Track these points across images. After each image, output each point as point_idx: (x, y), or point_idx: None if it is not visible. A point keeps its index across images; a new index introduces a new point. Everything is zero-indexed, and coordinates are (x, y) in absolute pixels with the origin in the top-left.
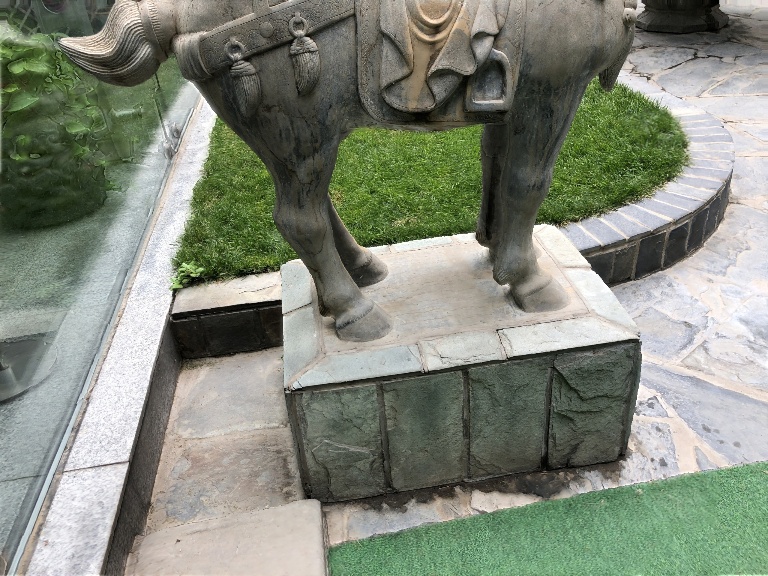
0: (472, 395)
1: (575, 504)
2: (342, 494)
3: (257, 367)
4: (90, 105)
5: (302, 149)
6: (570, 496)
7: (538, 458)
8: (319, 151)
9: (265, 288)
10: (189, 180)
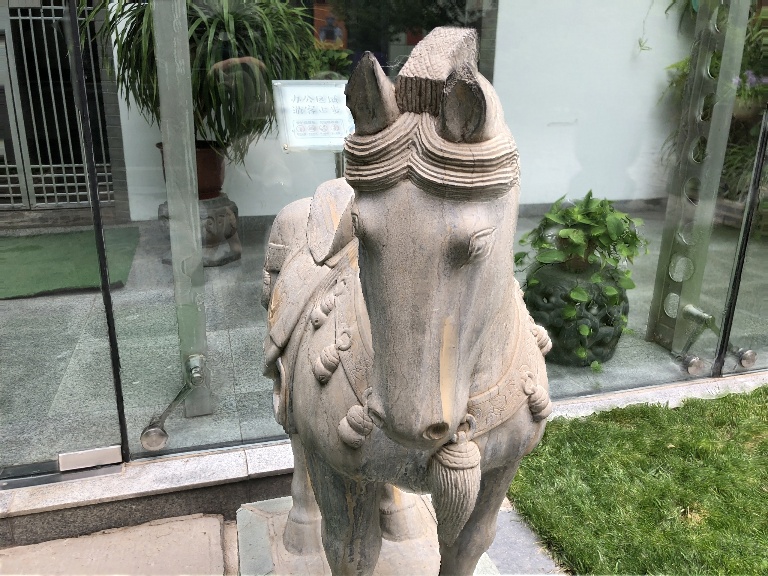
0: None
1: None
2: None
3: None
4: (676, 292)
5: None
6: None
7: None
8: None
9: None
10: (669, 401)
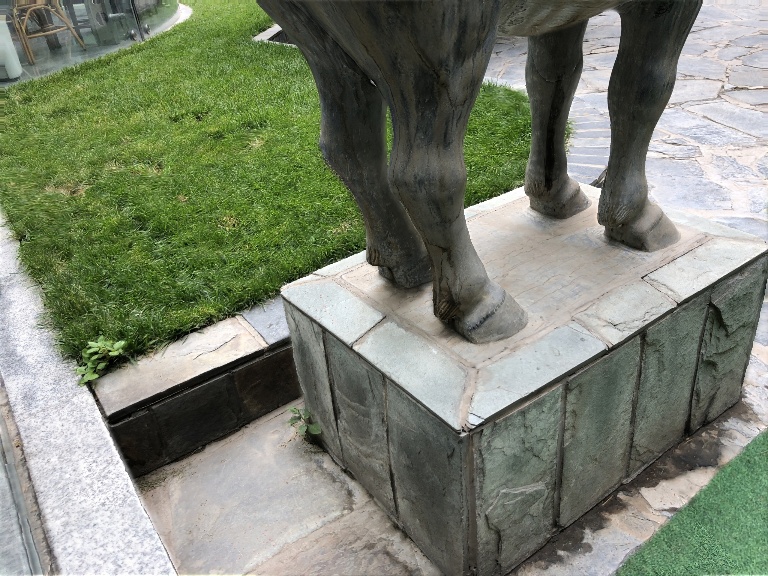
0: (643, 365)
1: (753, 458)
2: (511, 561)
3: (250, 452)
4: None
5: (464, 45)
6: (735, 453)
7: (683, 425)
8: (481, 49)
9: (226, 342)
10: None
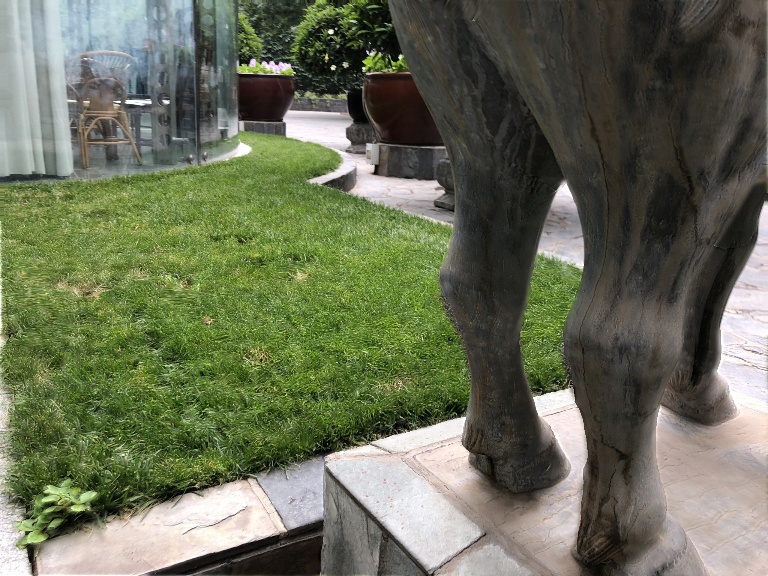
0: None
1: None
2: None
3: None
4: None
5: (739, 149)
6: None
7: None
8: (751, 161)
9: (231, 516)
10: None
